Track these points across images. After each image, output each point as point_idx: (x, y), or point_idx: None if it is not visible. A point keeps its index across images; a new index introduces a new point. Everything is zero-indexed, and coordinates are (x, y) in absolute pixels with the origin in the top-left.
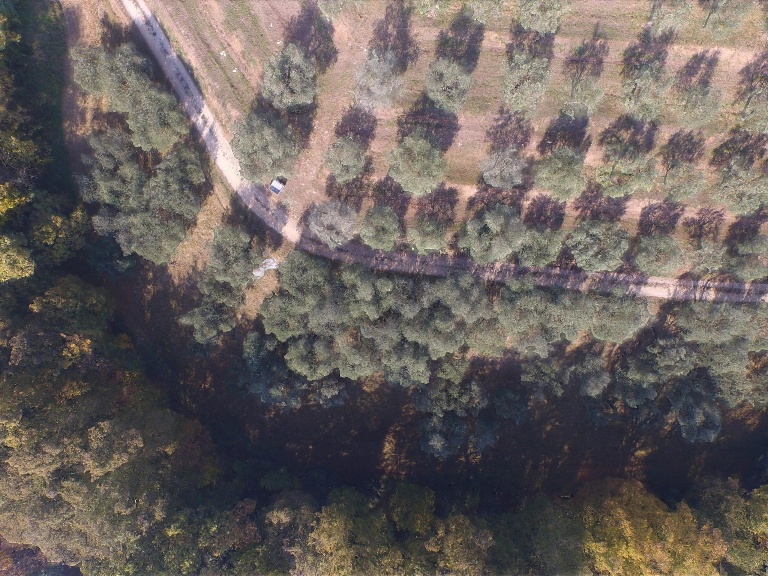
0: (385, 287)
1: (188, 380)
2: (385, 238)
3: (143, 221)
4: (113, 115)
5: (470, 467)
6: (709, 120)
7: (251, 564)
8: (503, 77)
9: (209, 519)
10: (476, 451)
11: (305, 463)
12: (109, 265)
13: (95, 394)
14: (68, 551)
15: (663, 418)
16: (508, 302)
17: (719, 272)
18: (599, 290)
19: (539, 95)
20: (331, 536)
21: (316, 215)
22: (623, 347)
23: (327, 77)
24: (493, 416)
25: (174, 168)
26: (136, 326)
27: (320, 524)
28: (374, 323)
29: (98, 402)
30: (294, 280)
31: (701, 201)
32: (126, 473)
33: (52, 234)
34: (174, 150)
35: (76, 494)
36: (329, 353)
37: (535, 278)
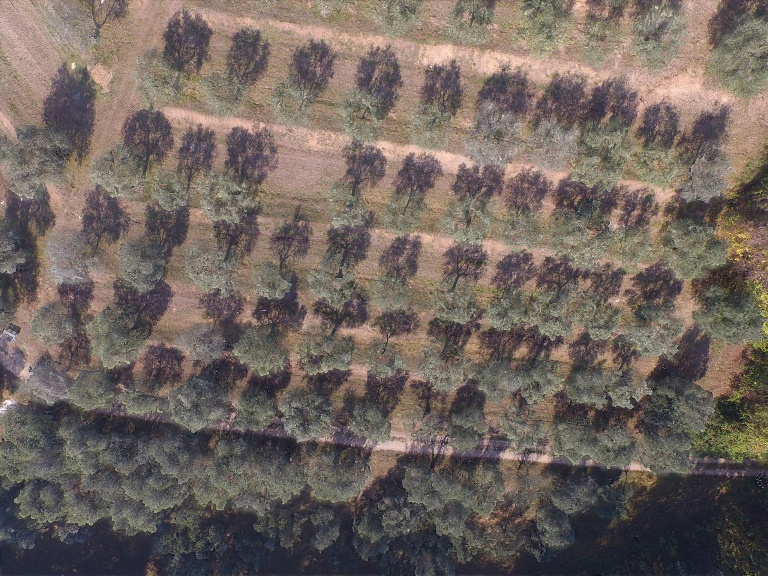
0: (92, 448)
1: None
2: (91, 402)
3: None
4: None
5: None
6: (418, 297)
7: None
8: (212, 250)
9: None
10: None
11: None
12: None
13: None
14: None
15: None
16: (214, 467)
17: None
18: (335, 443)
19: (219, 284)
20: None
21: (50, 363)
22: (367, 494)
23: (47, 239)
24: None
25: None
26: None
27: None
28: (92, 477)
29: None
30: (14, 432)
31: (422, 368)
32: None
33: None
34: None
35: None
36: (54, 500)
37: (271, 429)
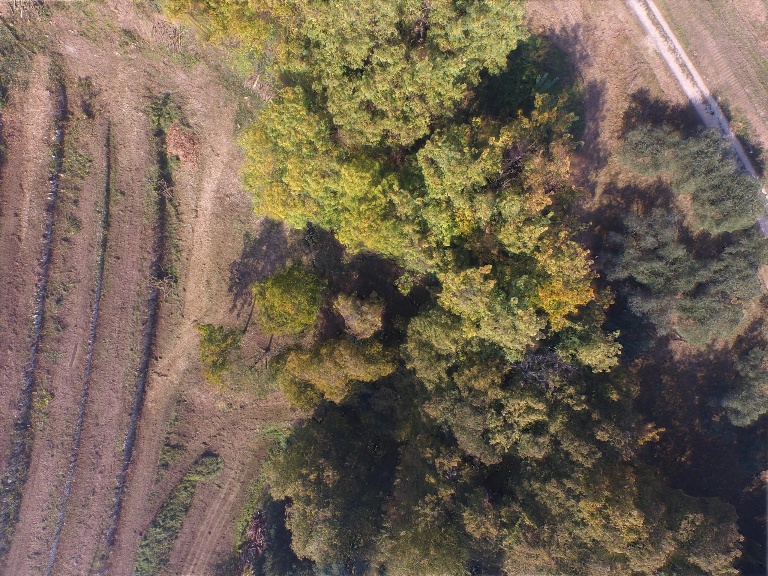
0: None
1: (663, 453)
2: None
3: (705, 305)
4: (631, 190)
5: None
6: None
7: None
8: None
9: None
10: None
11: None
12: (637, 345)
13: None
14: None
15: None
16: None
17: None
18: None
19: None
20: None
21: None
22: None
23: None
24: None
25: (746, 253)
26: None
27: None
28: None
29: None
30: None
31: None
32: None
33: (598, 316)
34: (743, 234)
35: None
36: None
37: None
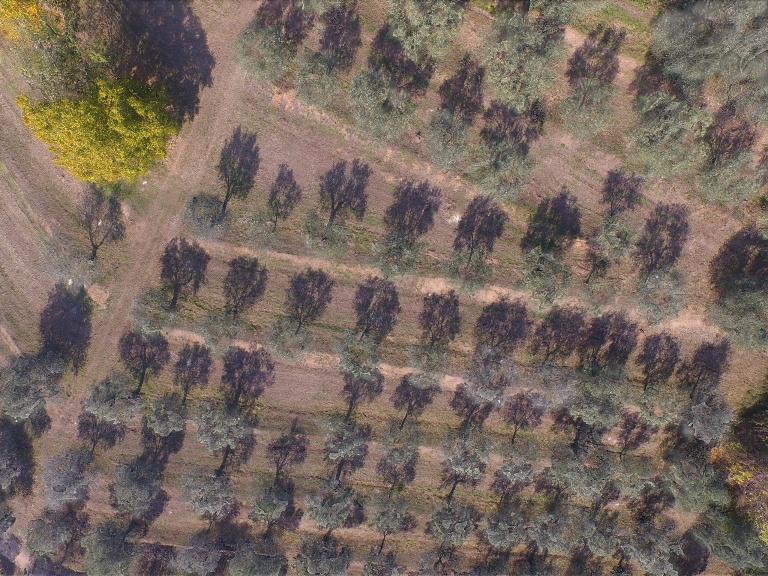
0: None
1: None
2: None
3: None
4: None
5: None
6: (416, 502)
7: None
8: (208, 458)
9: None
10: None
11: None
12: None
13: None
14: None
15: None
16: None
17: None
18: None
19: None
20: None
21: None
22: None
23: (42, 441)
24: None
25: None
26: None
27: None
28: None
29: None
30: None
31: (420, 564)
32: None
33: None
34: None
35: None
36: None
37: None
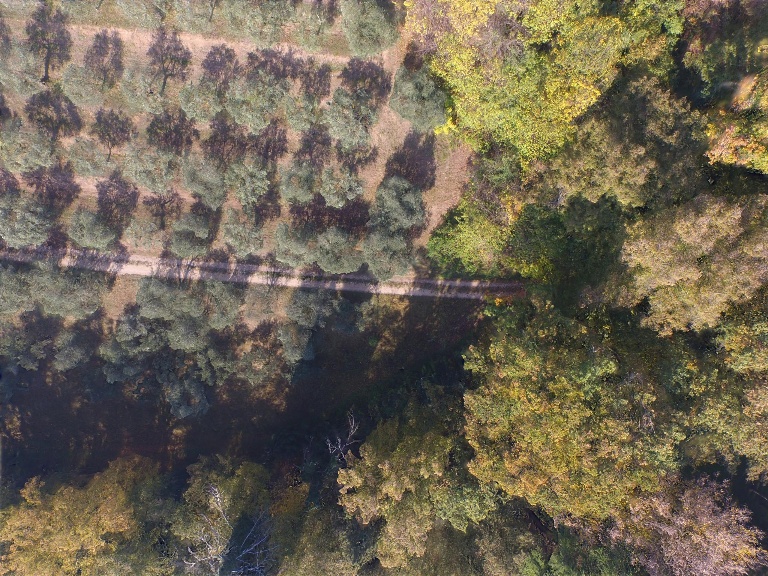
0: None
1: None
2: None
3: None
4: None
5: (16, 444)
6: None
7: None
8: None
9: None
10: (14, 427)
11: None
12: None
13: None
14: None
15: None
16: None
17: None
18: (78, 267)
19: None
20: None
21: None
22: None
23: None
24: (19, 392)
25: None
26: None
27: None
28: None
29: None
30: None
31: None
32: None
33: None
34: None
35: None
36: None
37: (12, 253)
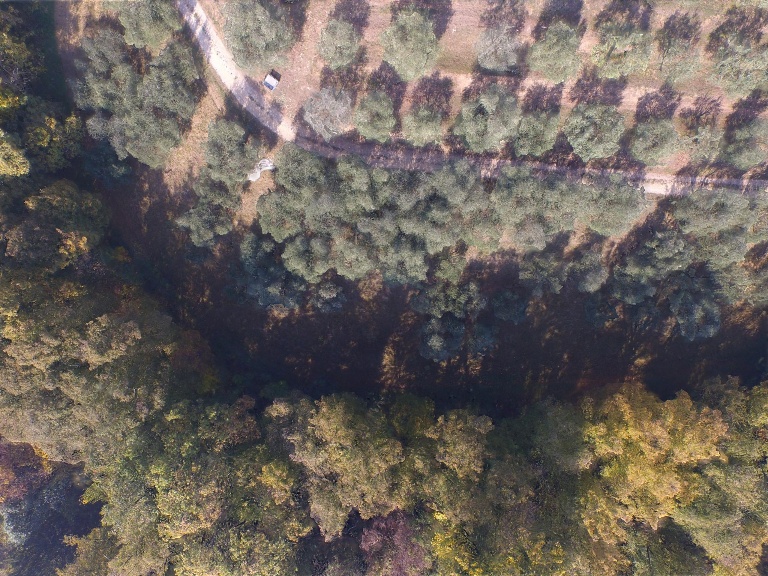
0: (381, 174)
1: (186, 294)
2: (380, 124)
3: (137, 120)
4: (106, 21)
5: (470, 379)
6: (705, 1)
7: (251, 459)
8: None
9: (208, 406)
10: (475, 362)
11: (305, 378)
12: (104, 170)
13: (93, 299)
14: (68, 448)
15: (662, 324)
16: (504, 188)
17: (717, 166)
18: None
19: None
20: (330, 418)
21: (311, 112)
22: (621, 248)
23: None
24: (492, 324)
25: (167, 64)
26: (133, 240)
27: (319, 412)
28: (370, 215)
29: (96, 303)
30: (289, 173)
31: (698, 89)
32: (124, 365)
33: (46, 137)
34: None
35: (75, 385)
36: (326, 250)
37: (532, 175)
